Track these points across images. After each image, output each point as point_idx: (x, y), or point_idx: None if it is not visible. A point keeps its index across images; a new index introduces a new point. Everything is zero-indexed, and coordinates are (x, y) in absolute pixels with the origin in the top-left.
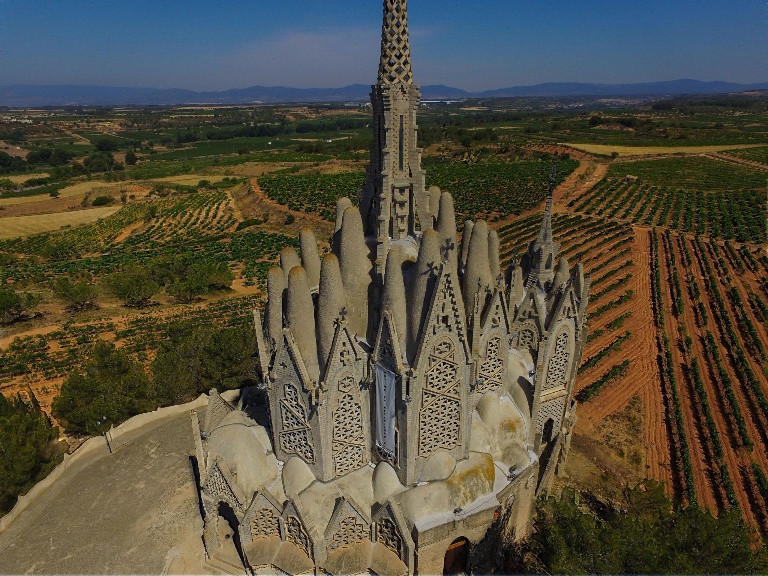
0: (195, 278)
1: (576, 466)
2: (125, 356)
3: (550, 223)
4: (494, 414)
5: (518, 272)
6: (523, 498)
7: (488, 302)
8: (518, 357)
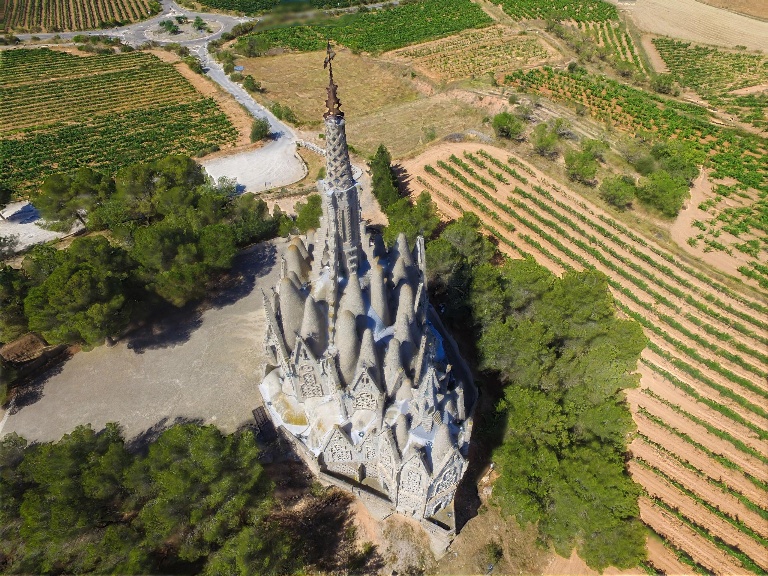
0: (643, 184)
1: (459, 575)
2: (434, 209)
3: (427, 384)
4: (323, 411)
5: (403, 383)
6: (307, 457)
7: (336, 358)
8: (372, 421)
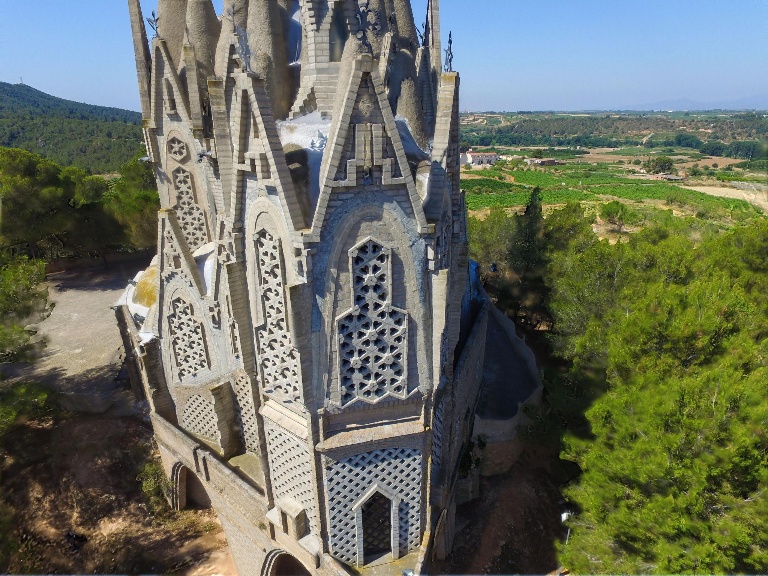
0: None
1: None
2: None
3: None
4: None
5: None
6: None
7: None
8: None
